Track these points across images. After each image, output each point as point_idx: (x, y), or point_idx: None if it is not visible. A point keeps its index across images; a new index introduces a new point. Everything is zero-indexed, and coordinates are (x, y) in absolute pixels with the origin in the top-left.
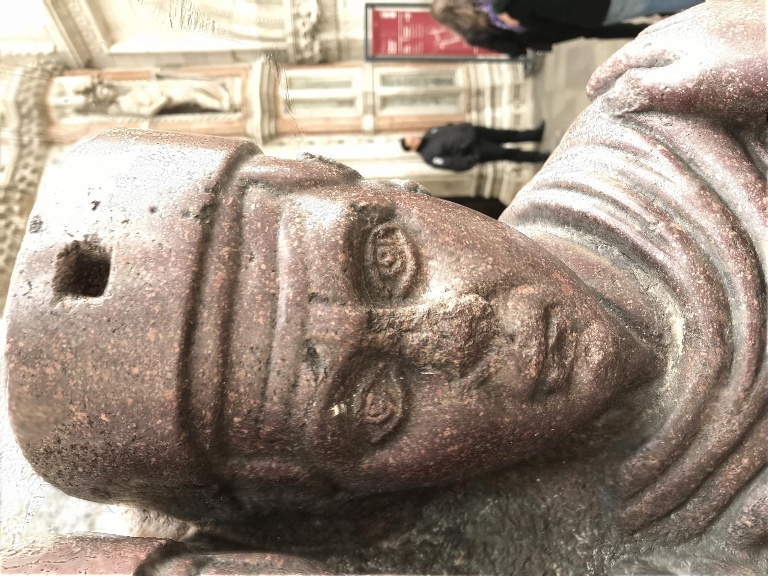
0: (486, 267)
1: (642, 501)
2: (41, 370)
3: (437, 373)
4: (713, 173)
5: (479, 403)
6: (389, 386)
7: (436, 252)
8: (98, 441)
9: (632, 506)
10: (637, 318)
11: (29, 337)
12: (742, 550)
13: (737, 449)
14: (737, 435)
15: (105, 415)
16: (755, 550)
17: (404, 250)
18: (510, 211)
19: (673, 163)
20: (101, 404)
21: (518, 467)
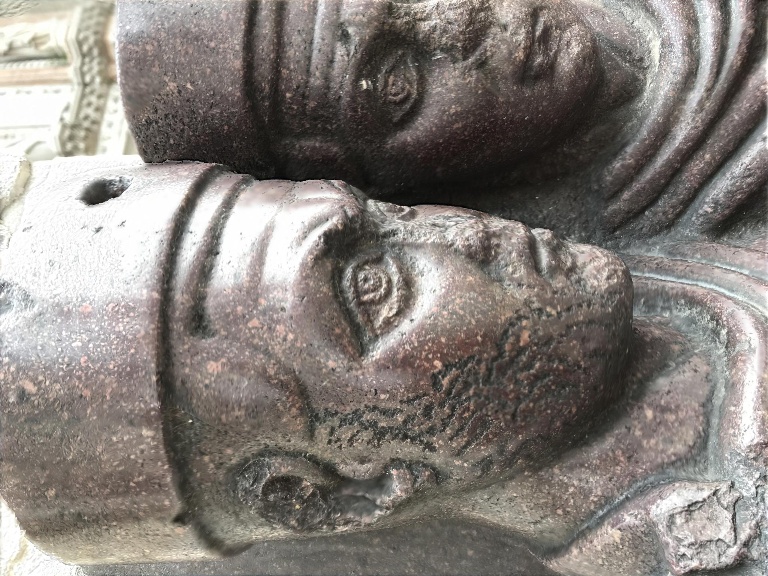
0: None
1: (621, 200)
2: (143, 47)
3: (444, 56)
4: None
5: (478, 82)
6: (407, 72)
7: None
8: (185, 109)
9: (612, 205)
10: (622, 46)
11: (134, 21)
12: (702, 233)
13: (701, 146)
14: (700, 131)
15: (190, 84)
16: (713, 233)
17: None
18: None
19: None
20: (187, 74)
21: (520, 187)
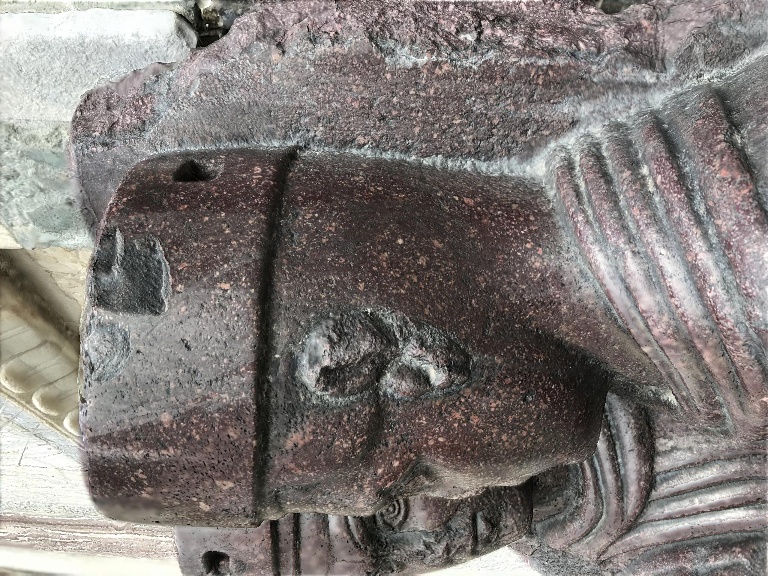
0: (492, 483)
1: None
2: None
3: None
4: None
5: None
6: None
7: (452, 476)
8: None
9: None
10: None
11: None
12: None
13: None
14: None
15: None
16: None
17: (423, 482)
18: (587, 260)
19: (762, 410)
20: None
21: None
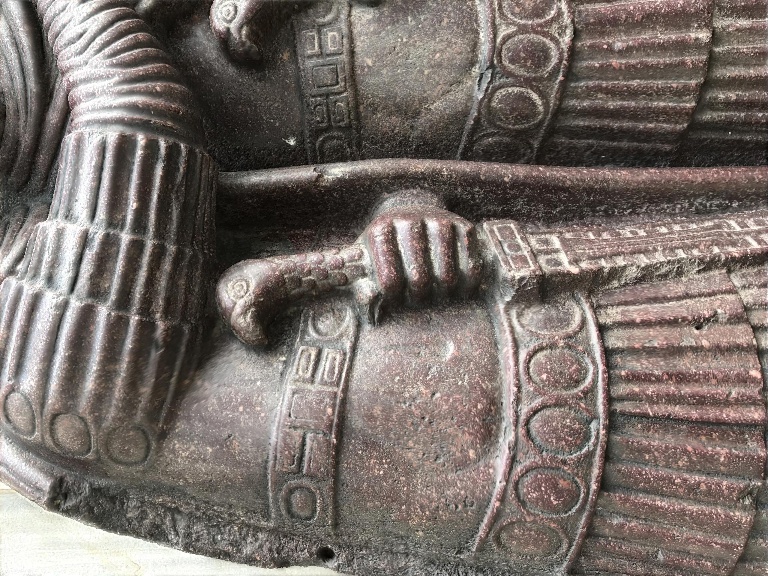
0: None
1: (11, 176)
2: None
3: None
4: (2, 3)
5: None
6: None
7: None
8: None
9: (9, 178)
10: None
11: None
12: None
13: (36, 150)
14: (29, 143)
15: None
16: None
17: None
18: None
19: None
20: None
21: None
